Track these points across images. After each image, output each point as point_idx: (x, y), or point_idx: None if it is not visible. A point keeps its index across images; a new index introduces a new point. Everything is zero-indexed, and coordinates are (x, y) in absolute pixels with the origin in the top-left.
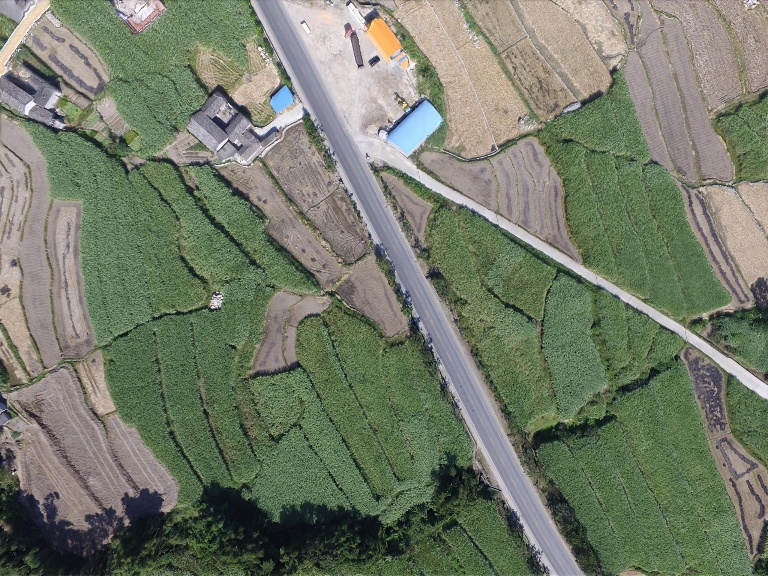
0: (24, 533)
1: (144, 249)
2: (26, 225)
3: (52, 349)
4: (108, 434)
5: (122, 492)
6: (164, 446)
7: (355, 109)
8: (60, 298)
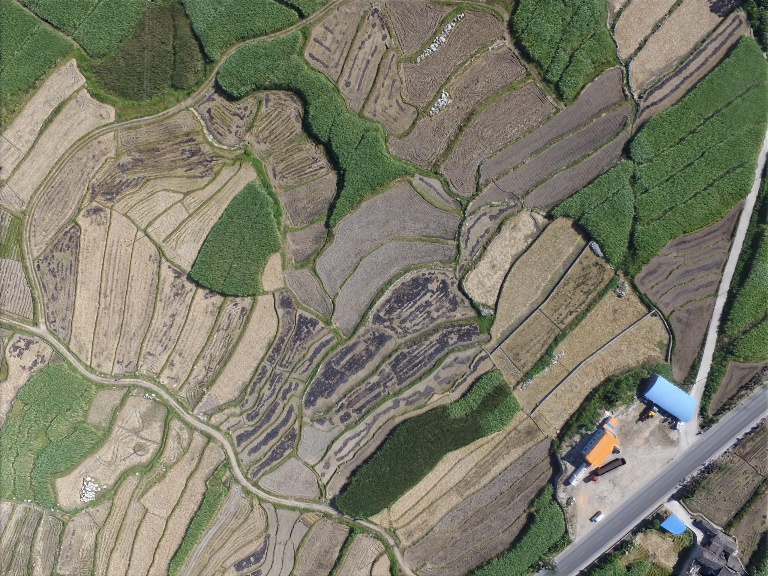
0: None
1: None
2: None
3: None
4: None
5: None
6: None
7: (659, 455)
8: None
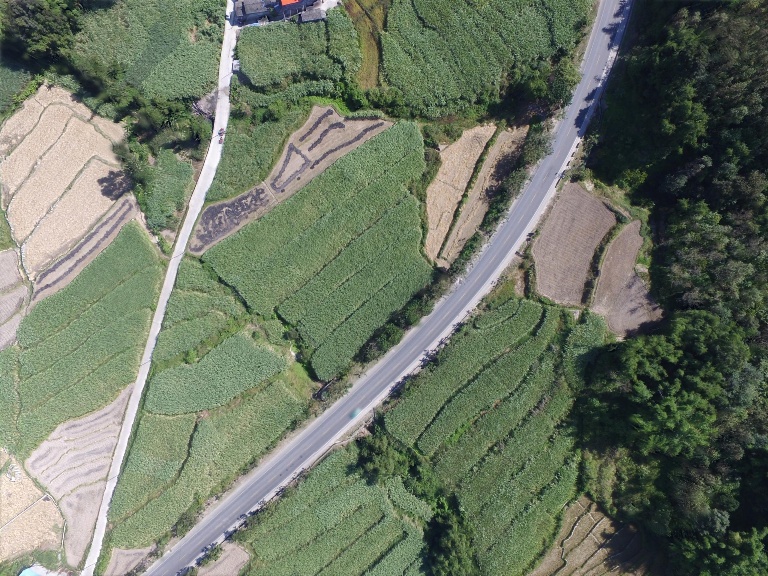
0: None
1: None
2: None
3: None
4: None
5: None
6: None
7: None
8: None
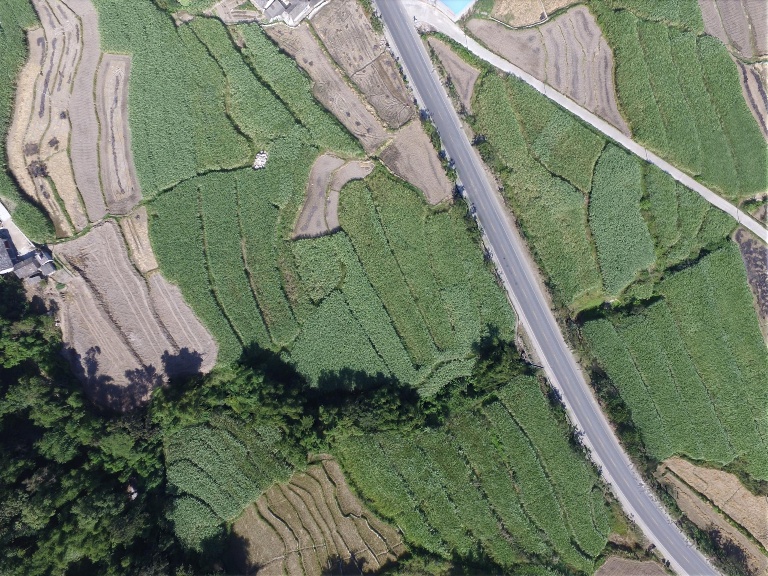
0: (66, 382)
1: (191, 103)
2: (76, 77)
3: (97, 203)
4: (150, 291)
5: (162, 349)
6: (205, 303)
7: None
8: (107, 153)
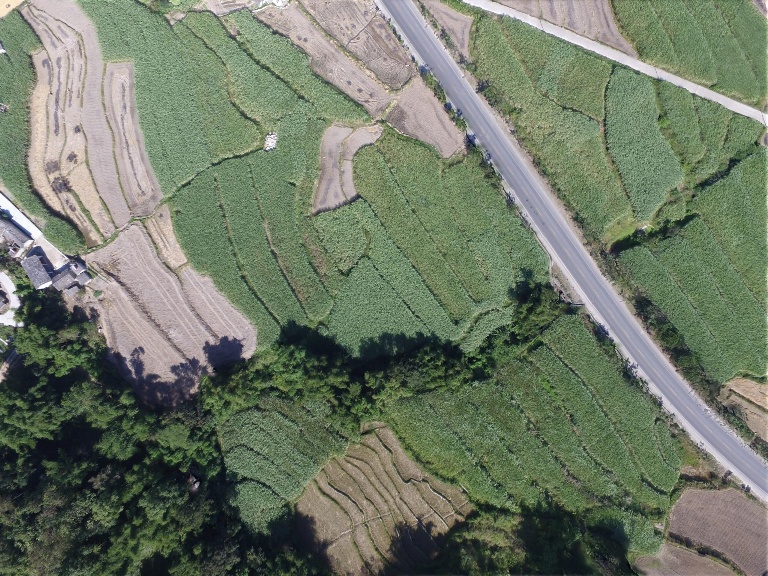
0: (116, 385)
1: (196, 97)
2: (84, 91)
3: (121, 209)
4: (183, 286)
5: (203, 341)
6: (237, 289)
7: None
8: (123, 159)
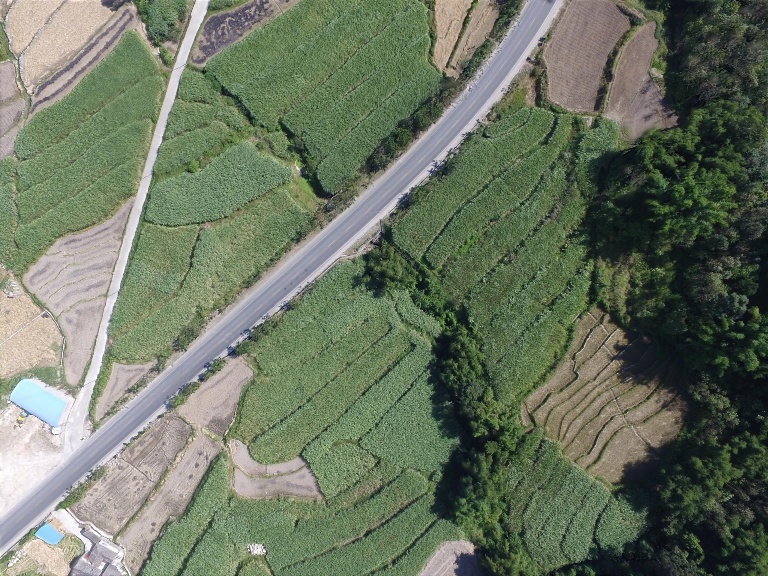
0: None
1: None
2: None
3: None
4: None
5: None
6: (406, 567)
7: (42, 462)
8: None
